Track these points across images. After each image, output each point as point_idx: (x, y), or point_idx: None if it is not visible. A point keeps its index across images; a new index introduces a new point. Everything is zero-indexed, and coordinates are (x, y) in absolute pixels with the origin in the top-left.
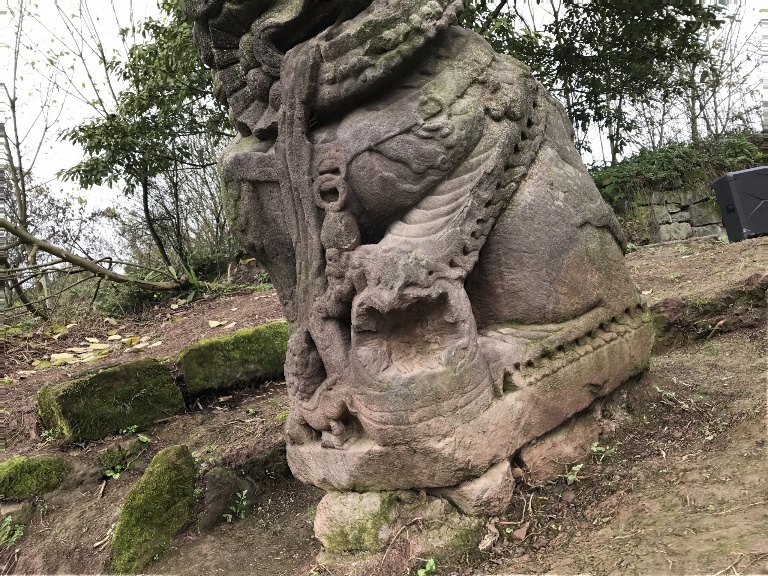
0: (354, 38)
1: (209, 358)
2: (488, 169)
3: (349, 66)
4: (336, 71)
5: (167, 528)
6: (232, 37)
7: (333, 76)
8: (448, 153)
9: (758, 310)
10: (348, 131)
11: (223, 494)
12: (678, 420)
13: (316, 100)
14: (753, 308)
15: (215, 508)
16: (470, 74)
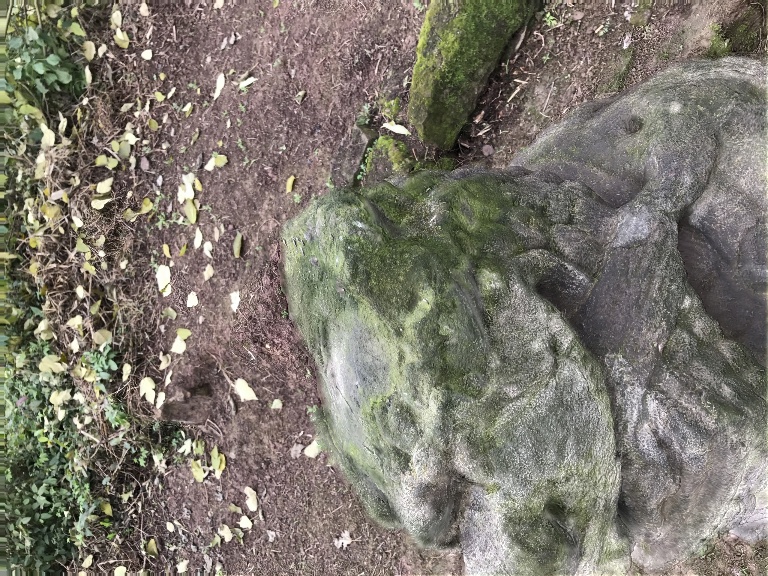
0: None
1: (442, 109)
2: None
3: None
4: None
5: None
6: None
7: None
8: None
9: None
10: None
11: None
12: None
13: None
14: None
15: None
16: None
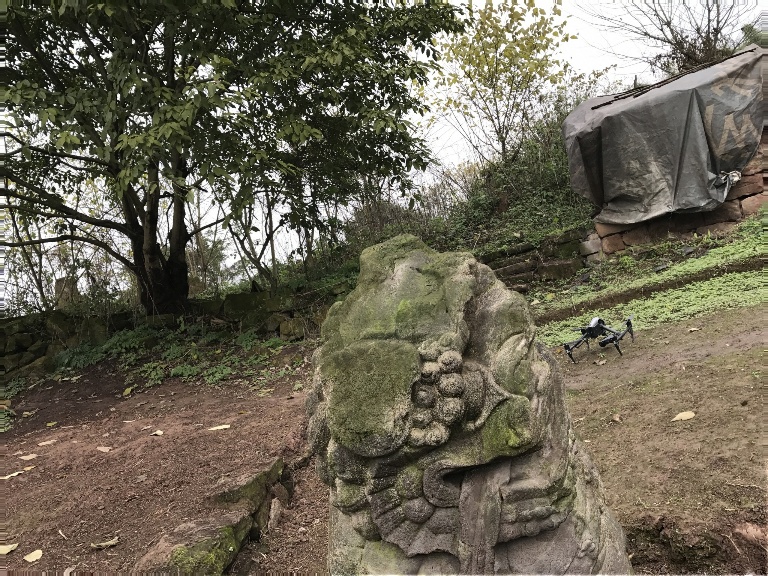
0: (544, 491)
1: None
2: (609, 562)
3: (536, 513)
4: (518, 513)
5: None
6: (394, 469)
7: (516, 518)
8: (593, 563)
9: (656, 546)
10: (528, 565)
11: None
12: None
13: (498, 538)
14: (652, 544)
15: None
16: (584, 478)
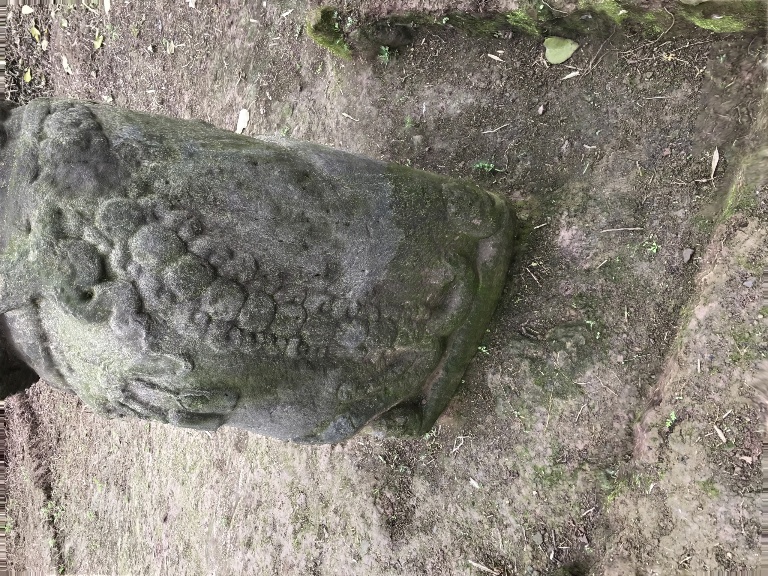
0: None
1: None
2: None
3: None
4: None
5: None
6: None
7: None
8: None
9: None
10: None
11: (370, 47)
12: (420, 437)
13: None
14: None
15: (368, 52)
16: None
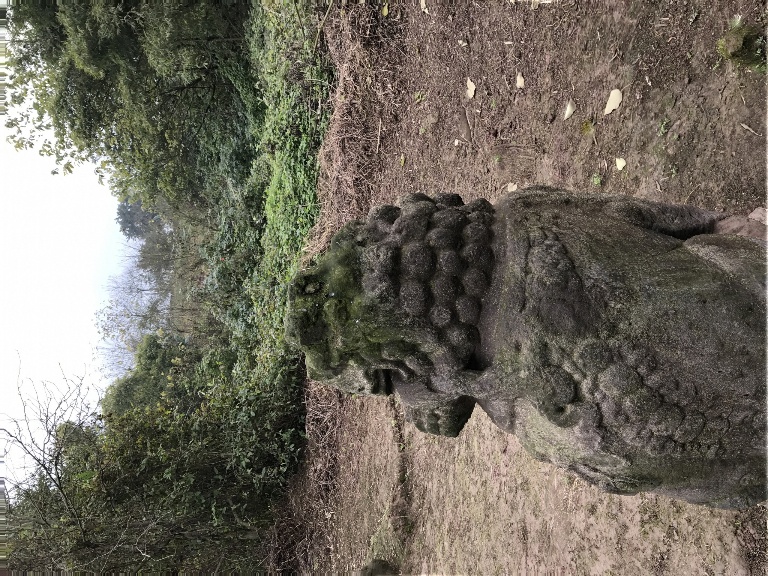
0: None
1: None
2: None
3: None
4: None
5: (757, 63)
6: None
7: None
8: None
9: None
10: None
11: None
12: None
13: None
14: None
15: None
16: None
